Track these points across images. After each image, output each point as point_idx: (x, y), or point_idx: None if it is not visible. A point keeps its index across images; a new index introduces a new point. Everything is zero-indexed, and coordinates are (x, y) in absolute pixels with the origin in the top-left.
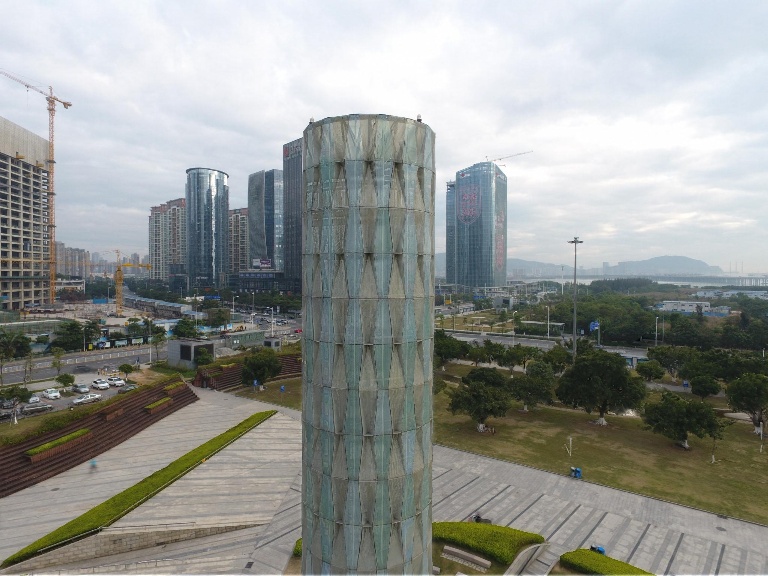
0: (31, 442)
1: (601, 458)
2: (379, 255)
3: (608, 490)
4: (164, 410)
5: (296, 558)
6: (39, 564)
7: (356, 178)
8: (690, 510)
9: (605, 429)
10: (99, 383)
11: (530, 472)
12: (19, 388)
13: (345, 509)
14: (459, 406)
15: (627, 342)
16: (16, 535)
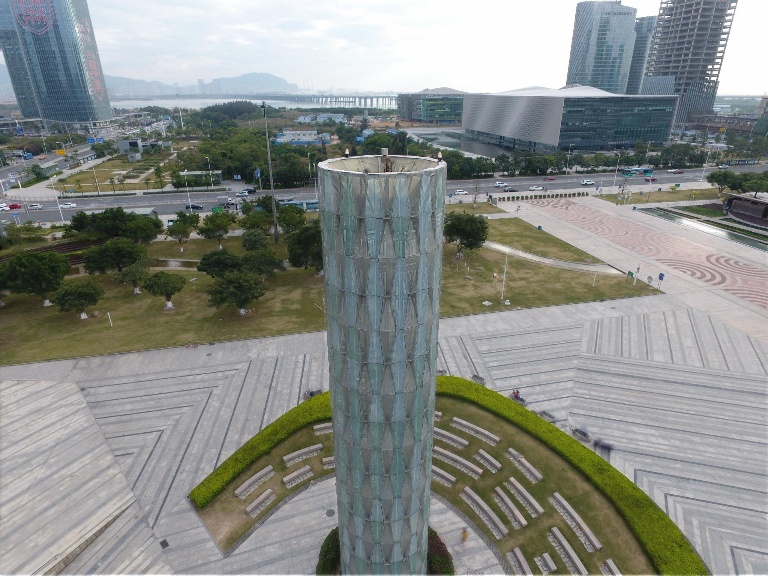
0: None
1: None
2: None
3: None
4: None
5: (204, 509)
6: None
7: (423, 228)
8: None
9: None
10: None
11: (309, 337)
12: None
13: (412, 461)
14: (226, 301)
15: (295, 189)
16: None
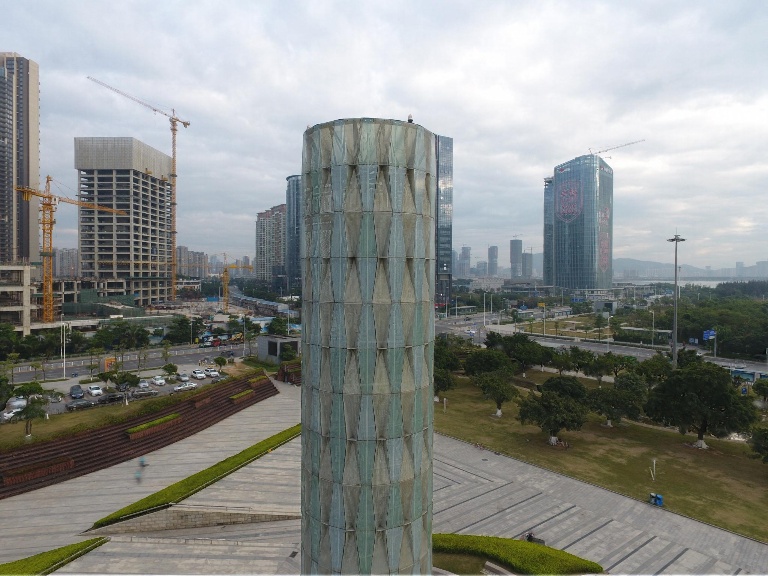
0: (132, 422)
1: (692, 486)
2: (363, 259)
3: (694, 523)
4: (246, 401)
5: None
6: (121, 529)
7: (341, 183)
8: None
9: (704, 453)
10: (197, 373)
11: (602, 493)
12: None
13: (330, 511)
14: (527, 416)
15: (748, 355)
16: (109, 502)
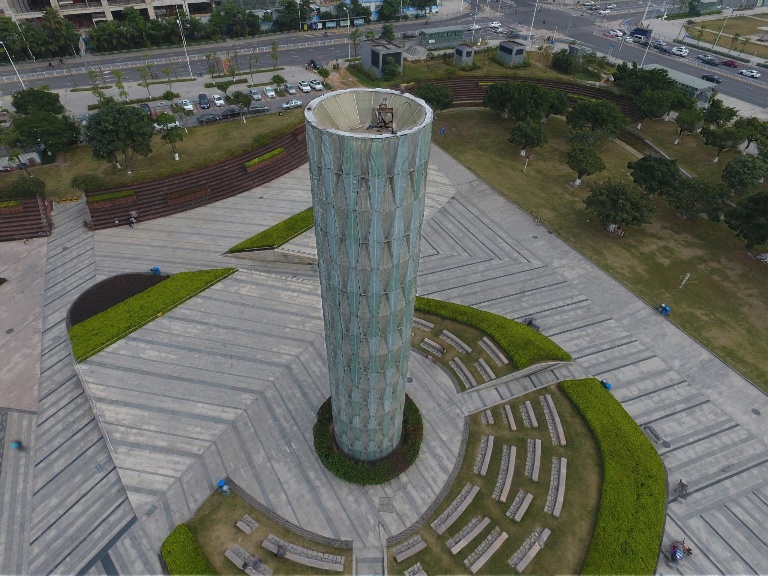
0: (247, 155)
1: (713, 301)
2: (349, 241)
3: (682, 336)
4: None
5: None
6: (246, 257)
7: (331, 183)
8: (747, 384)
9: (760, 267)
10: (303, 86)
11: (620, 292)
12: (242, 94)
13: (336, 357)
14: (591, 206)
15: None
16: (238, 230)
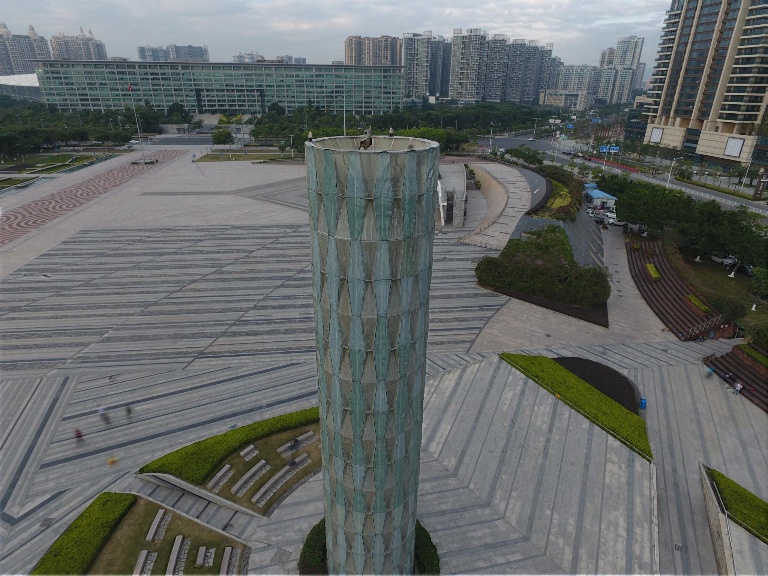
0: None
1: None
2: None
3: None
4: None
5: None
6: None
7: None
8: None
9: None
10: None
11: None
12: None
13: None
14: None
15: None
16: None
